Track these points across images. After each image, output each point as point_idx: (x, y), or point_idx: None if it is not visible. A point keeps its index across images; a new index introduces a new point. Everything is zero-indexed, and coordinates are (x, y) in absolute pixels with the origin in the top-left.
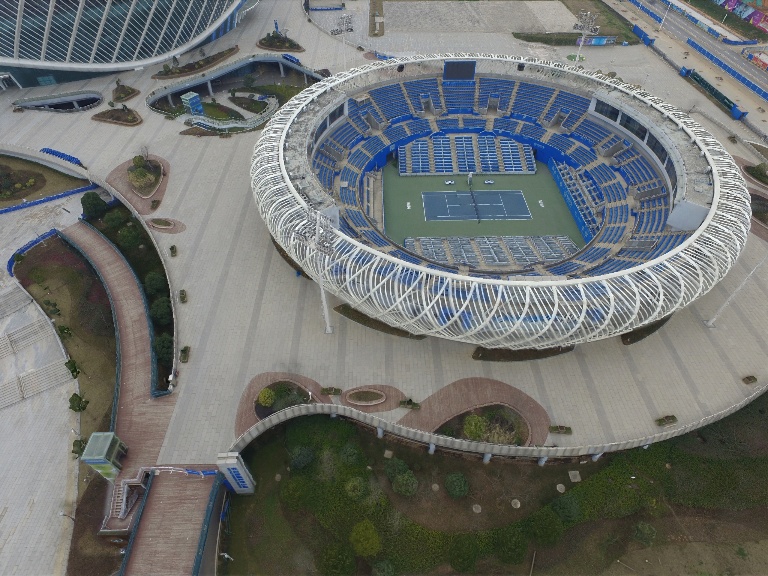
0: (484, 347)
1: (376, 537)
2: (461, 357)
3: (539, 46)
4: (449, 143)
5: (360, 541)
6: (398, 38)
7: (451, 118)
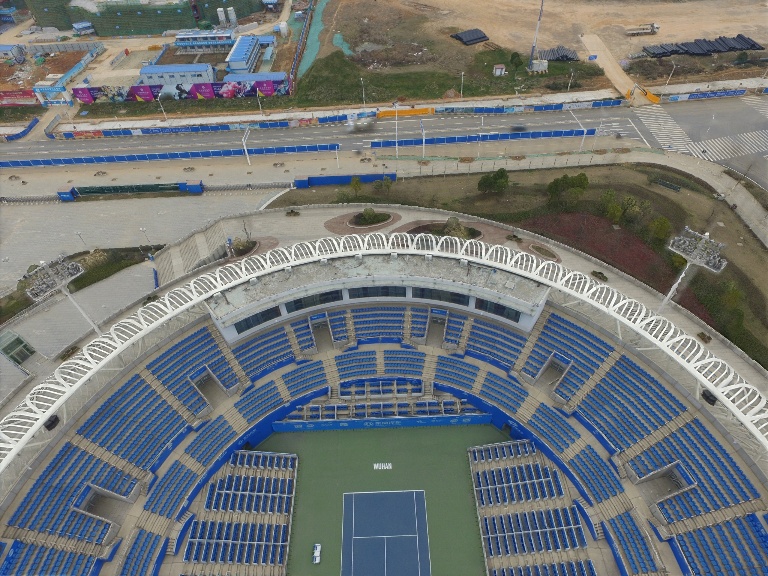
0: None
1: None
2: None
3: None
4: None
5: None
6: None
7: None
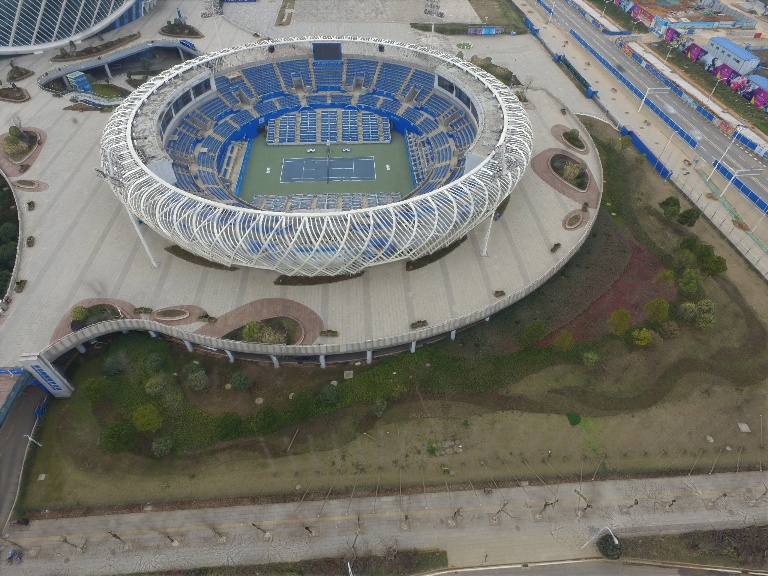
0: (284, 274)
1: (153, 415)
2: (264, 283)
3: None
4: (315, 117)
5: (138, 418)
6: (302, 27)
7: (320, 95)
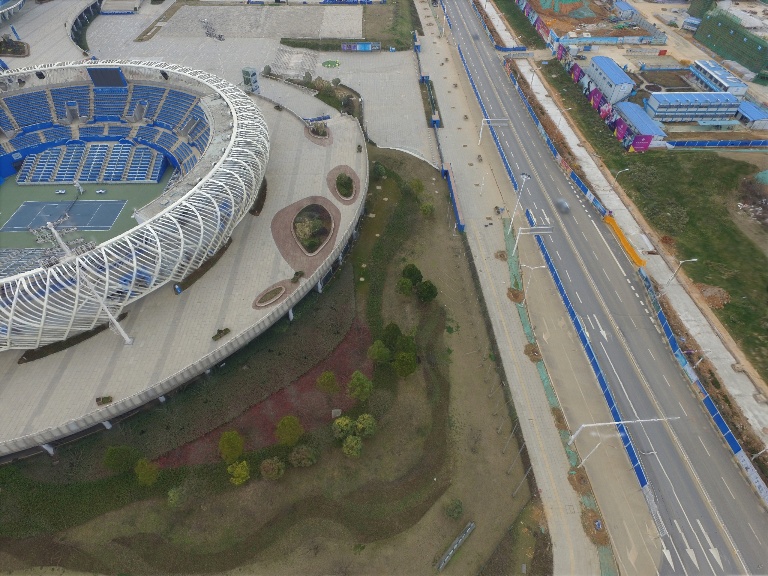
0: None
1: None
2: None
3: (298, 52)
4: (82, 151)
5: None
6: (160, 43)
7: (96, 126)
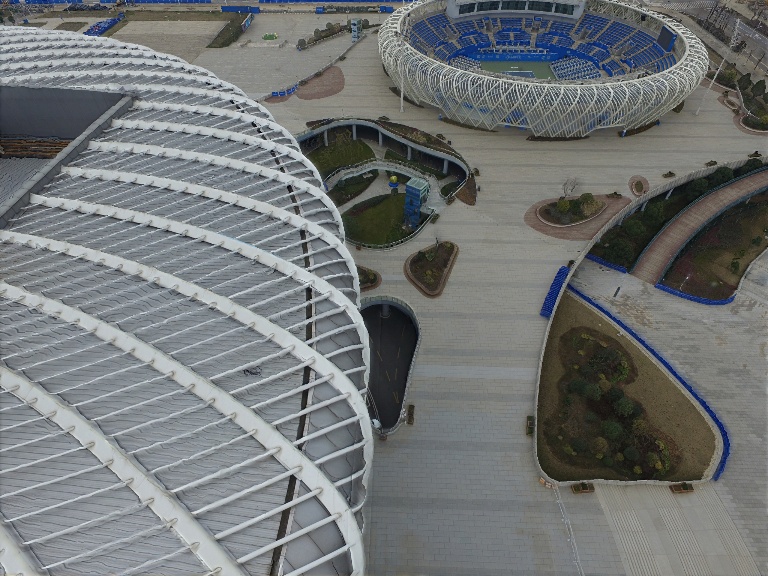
0: None
1: None
2: None
3: (245, 43)
4: None
5: None
6: None
7: None
